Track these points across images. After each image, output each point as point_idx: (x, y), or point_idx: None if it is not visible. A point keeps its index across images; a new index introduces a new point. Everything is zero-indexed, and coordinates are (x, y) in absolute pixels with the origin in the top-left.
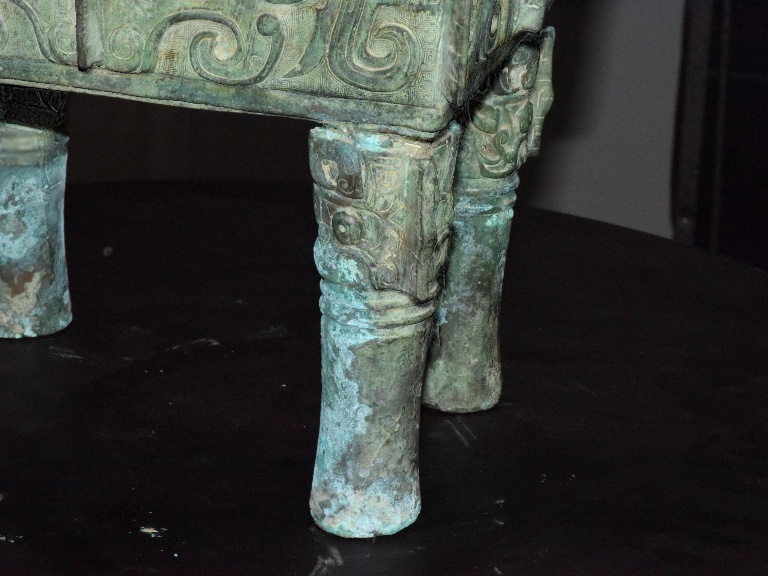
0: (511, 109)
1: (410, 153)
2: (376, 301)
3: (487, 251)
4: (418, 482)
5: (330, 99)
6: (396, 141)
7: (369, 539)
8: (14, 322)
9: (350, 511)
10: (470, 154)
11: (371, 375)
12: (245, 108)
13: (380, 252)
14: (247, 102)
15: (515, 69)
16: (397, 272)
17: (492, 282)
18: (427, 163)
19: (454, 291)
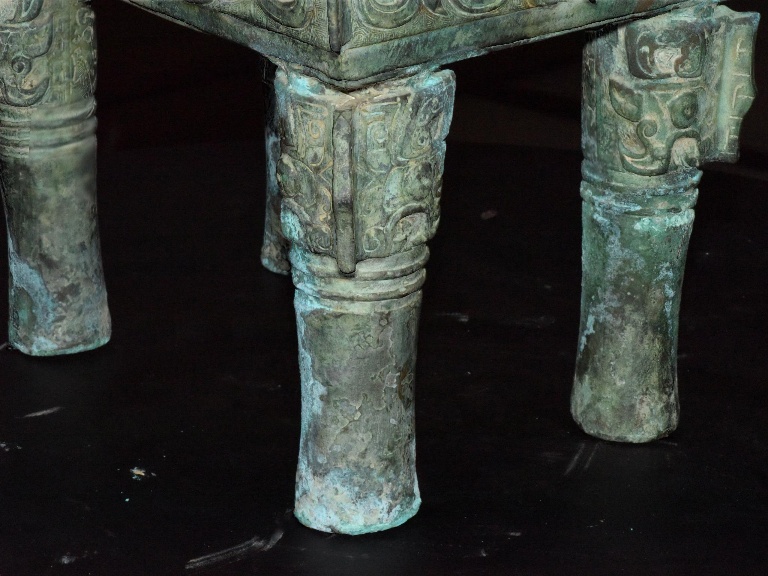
0: (659, 97)
1: (336, 103)
2: (319, 266)
3: (637, 259)
4: (402, 486)
5: (261, 29)
6: (328, 88)
7: (327, 534)
8: (282, 257)
9: (309, 498)
10: (613, 142)
11: (321, 349)
12: (208, 30)
13: (315, 211)
14: (208, 23)
15: (665, 51)
16: (332, 237)
17: (647, 296)
18: (337, 115)
19: (601, 298)
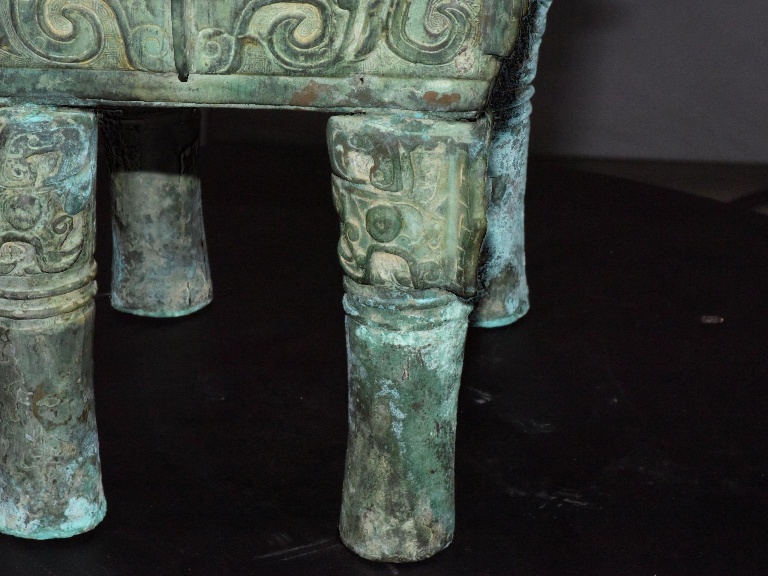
0: (359, 202)
1: None
2: None
3: None
4: (44, 503)
5: None
6: None
7: None
8: None
9: None
10: None
11: None
12: None
13: None
14: None
15: (362, 155)
16: None
17: (372, 409)
18: None
19: None
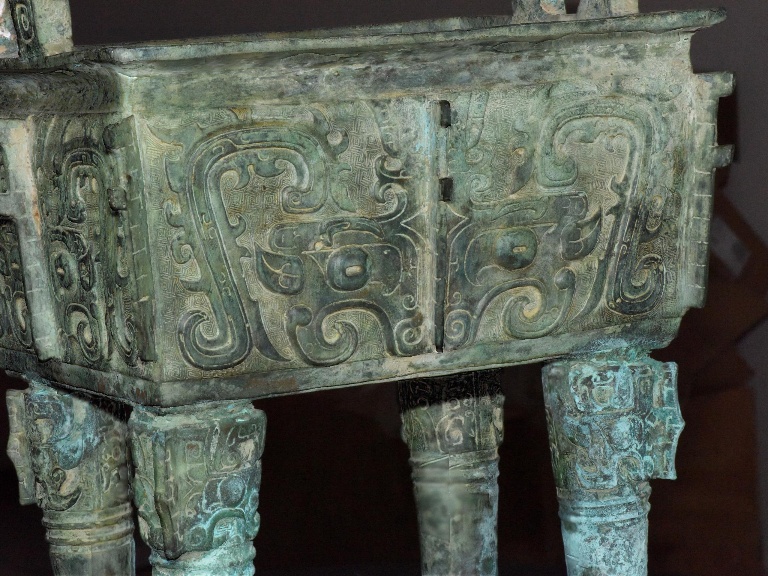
0: None
1: None
2: None
3: None
4: None
5: None
6: None
7: None
8: None
9: None
10: None
11: None
12: None
13: None
14: None
15: None
16: None
17: None
18: None
19: None
